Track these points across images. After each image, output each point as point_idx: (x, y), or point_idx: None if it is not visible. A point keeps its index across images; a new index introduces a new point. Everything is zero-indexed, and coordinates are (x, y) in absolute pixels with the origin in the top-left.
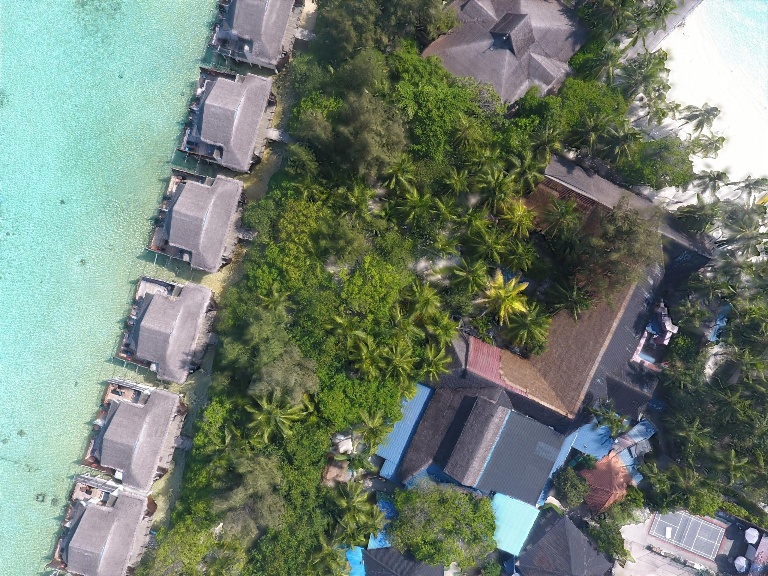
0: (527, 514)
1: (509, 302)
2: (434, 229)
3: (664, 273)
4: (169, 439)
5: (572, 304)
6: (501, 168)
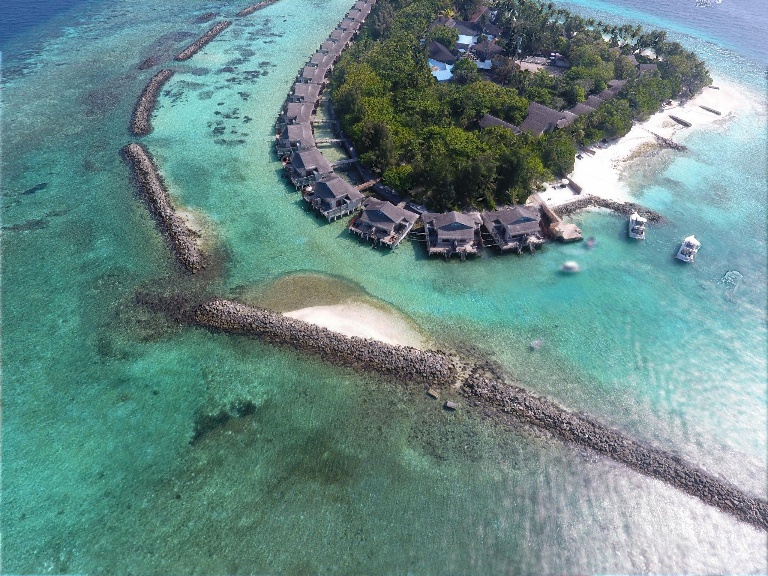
0: (469, 37)
1: (448, 10)
2: None
3: (495, 18)
4: (349, 44)
5: (467, 13)
6: None
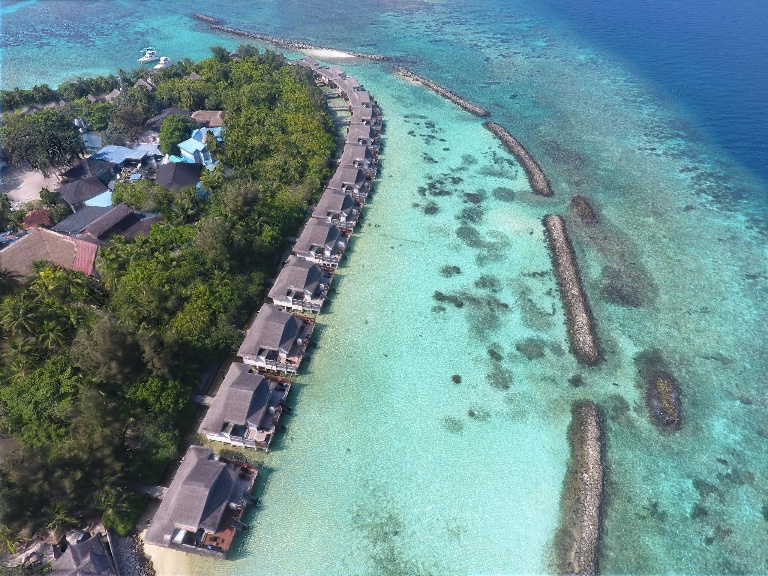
0: None
1: None
2: (86, 310)
3: None
4: None
5: None
6: (8, 340)
